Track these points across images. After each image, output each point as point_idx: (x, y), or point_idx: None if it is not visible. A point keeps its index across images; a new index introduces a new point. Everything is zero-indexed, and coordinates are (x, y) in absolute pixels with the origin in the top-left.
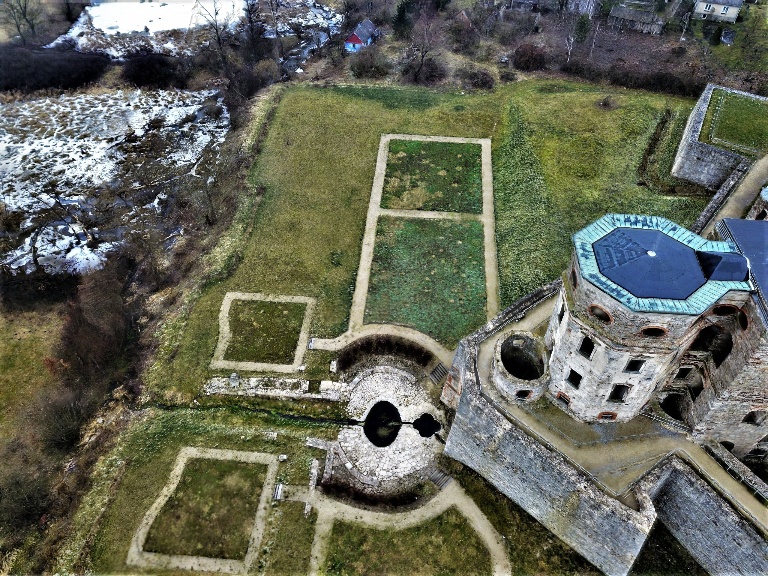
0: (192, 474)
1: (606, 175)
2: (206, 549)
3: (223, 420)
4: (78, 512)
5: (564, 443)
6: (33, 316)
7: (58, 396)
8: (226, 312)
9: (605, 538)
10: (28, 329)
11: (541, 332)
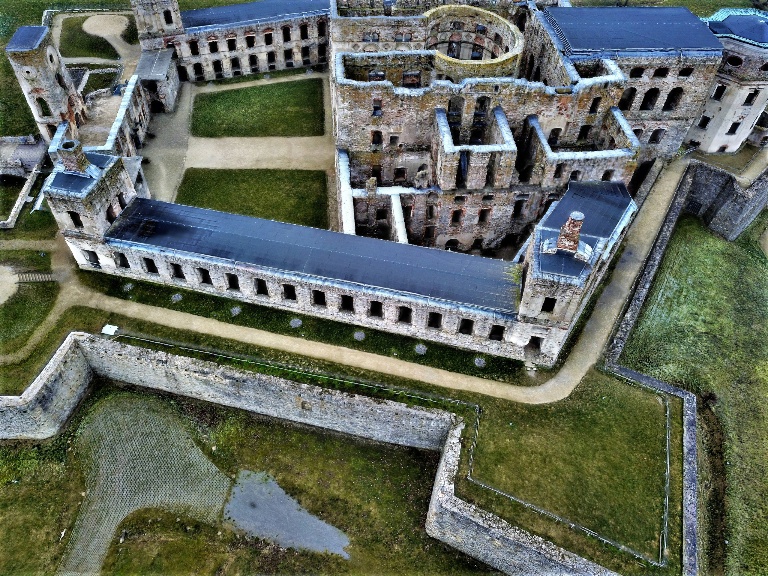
0: None
1: (763, 412)
2: None
3: None
4: None
5: None
6: None
7: None
8: None
9: None
10: None
11: (751, 156)
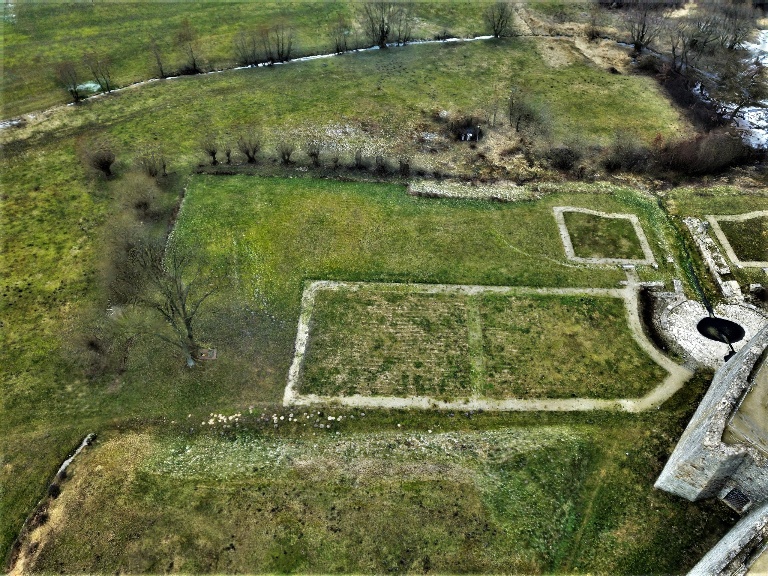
0: (619, 223)
1: None
2: (575, 238)
3: (667, 233)
4: (573, 182)
5: (764, 396)
6: (690, 127)
7: (639, 155)
8: (763, 214)
9: (688, 445)
10: (679, 128)
11: None
